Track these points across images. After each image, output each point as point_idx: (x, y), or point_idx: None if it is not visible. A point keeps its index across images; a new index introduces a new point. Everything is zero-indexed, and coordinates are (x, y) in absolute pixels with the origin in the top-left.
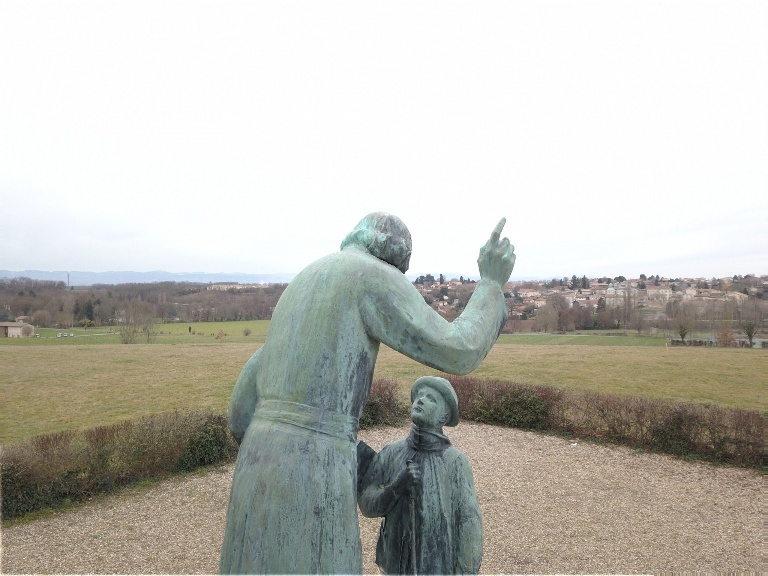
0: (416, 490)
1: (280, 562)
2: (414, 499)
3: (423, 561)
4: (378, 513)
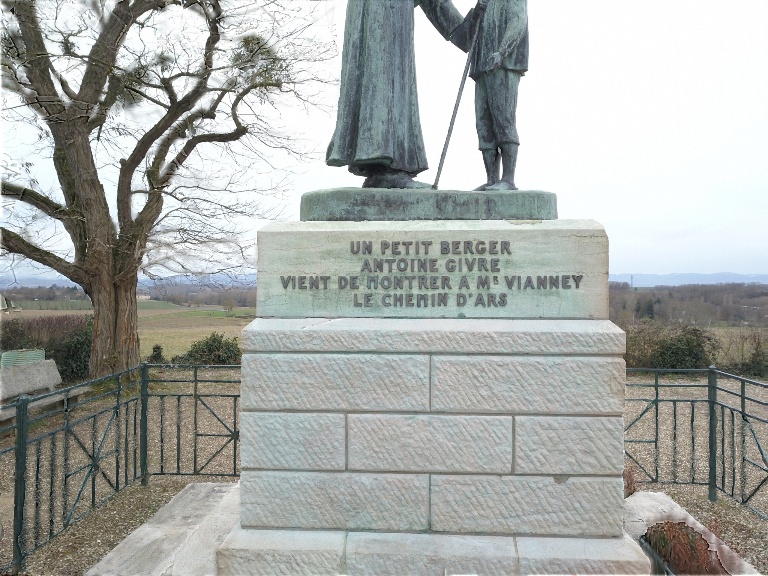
0: (483, 13)
1: (353, 5)
2: (481, 19)
3: (483, 56)
4: (469, 41)
